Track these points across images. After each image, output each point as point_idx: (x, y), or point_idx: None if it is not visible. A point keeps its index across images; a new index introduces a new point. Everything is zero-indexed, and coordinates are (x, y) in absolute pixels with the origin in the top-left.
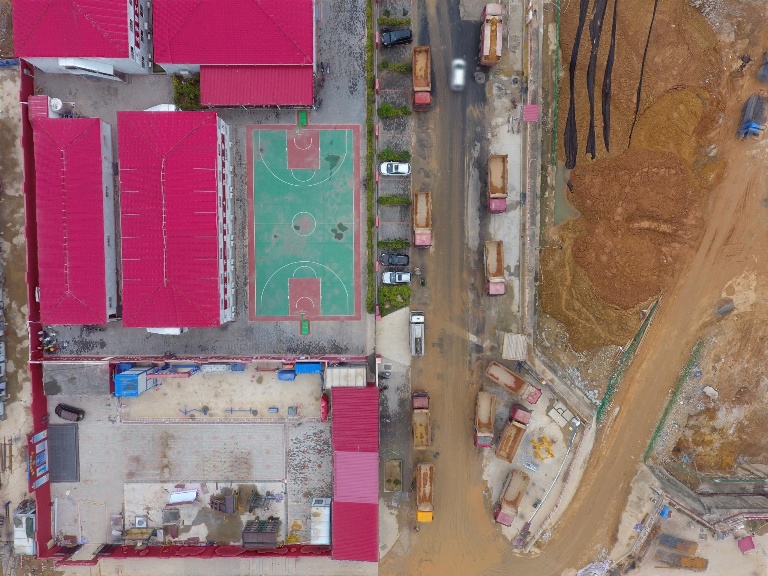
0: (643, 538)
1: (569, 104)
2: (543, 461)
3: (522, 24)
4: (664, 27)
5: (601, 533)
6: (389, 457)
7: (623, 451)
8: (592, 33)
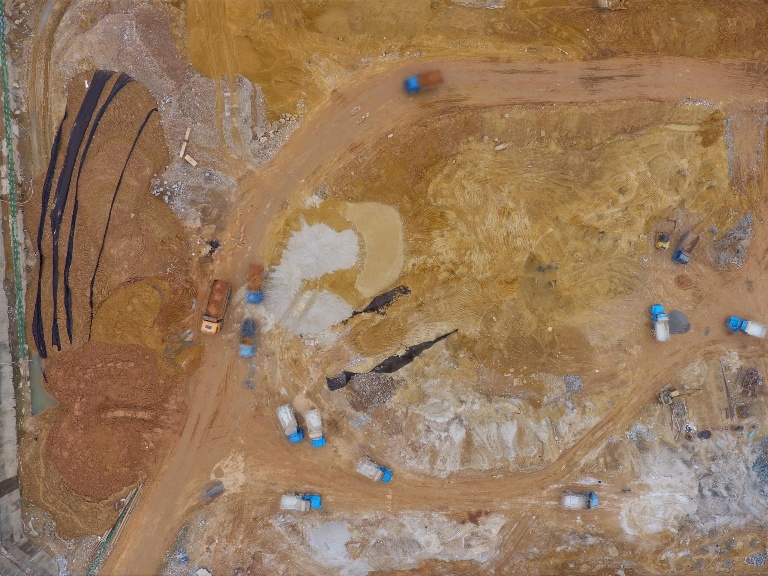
0: None
1: (36, 294)
2: None
3: None
4: (121, 217)
5: None
6: None
7: None
8: (52, 224)
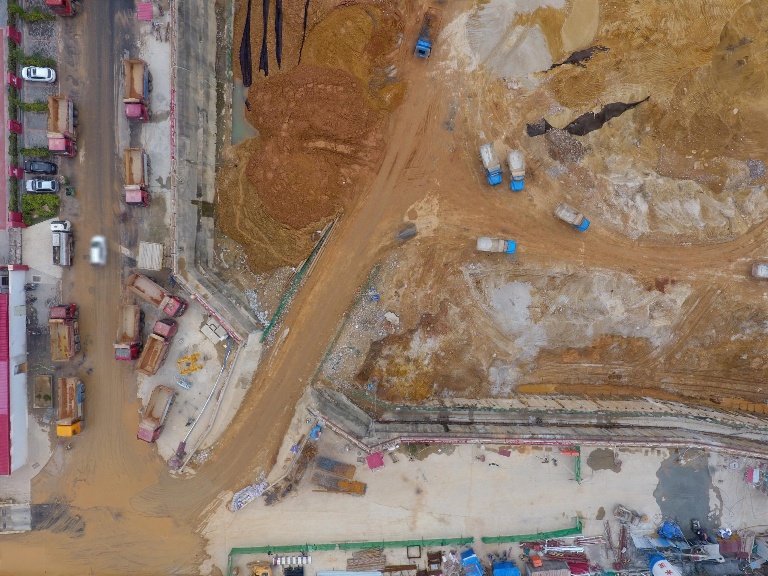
0: (296, 459)
1: (245, 21)
2: (197, 379)
3: None
4: None
5: (261, 456)
6: (39, 372)
7: (291, 373)
8: None
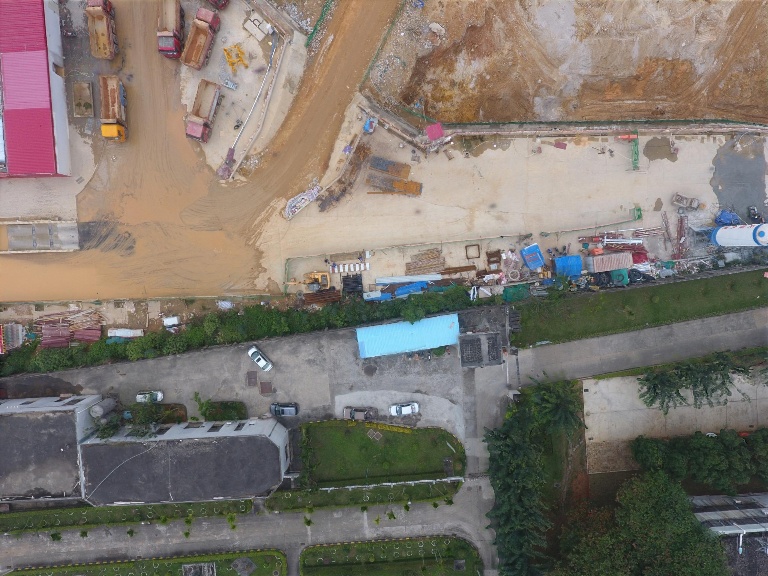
0: None
1: None
2: (243, 80)
3: None
4: None
5: (313, 162)
6: (77, 79)
7: (338, 81)
8: None
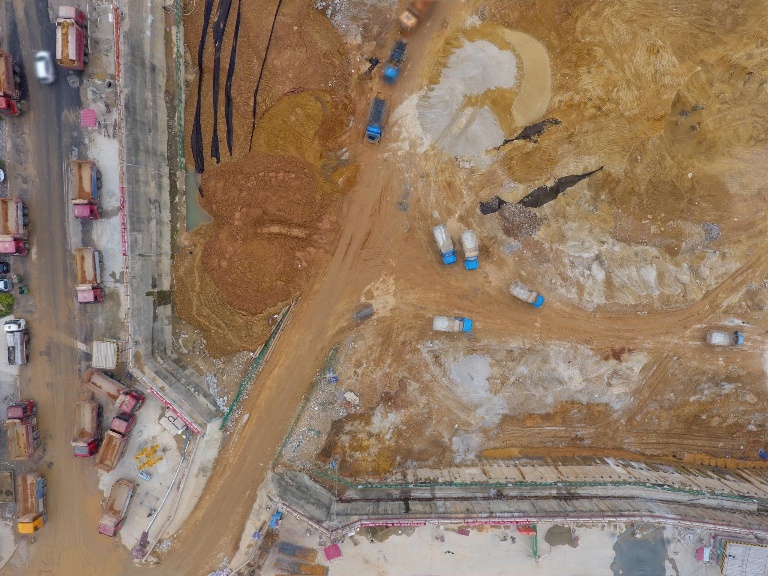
0: (258, 546)
1: (196, 108)
2: (157, 470)
3: (113, 27)
4: (285, 29)
5: (224, 541)
6: (0, 468)
7: (252, 458)
8: (215, 35)
